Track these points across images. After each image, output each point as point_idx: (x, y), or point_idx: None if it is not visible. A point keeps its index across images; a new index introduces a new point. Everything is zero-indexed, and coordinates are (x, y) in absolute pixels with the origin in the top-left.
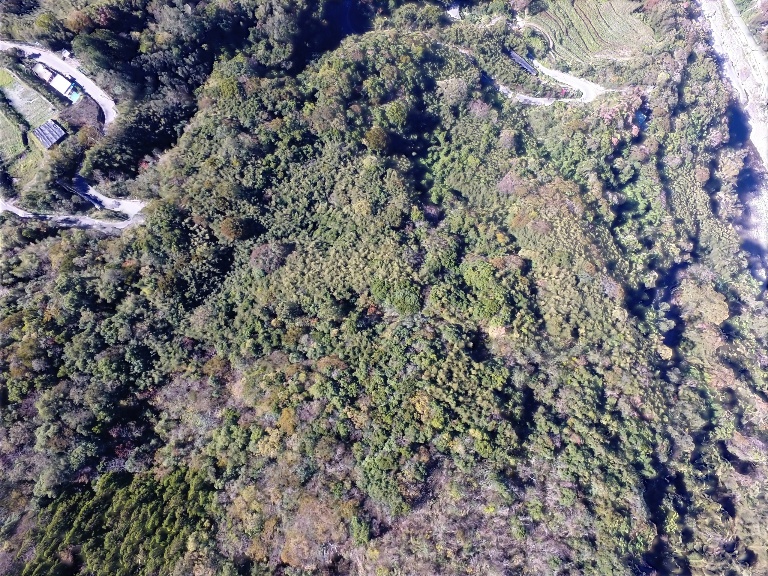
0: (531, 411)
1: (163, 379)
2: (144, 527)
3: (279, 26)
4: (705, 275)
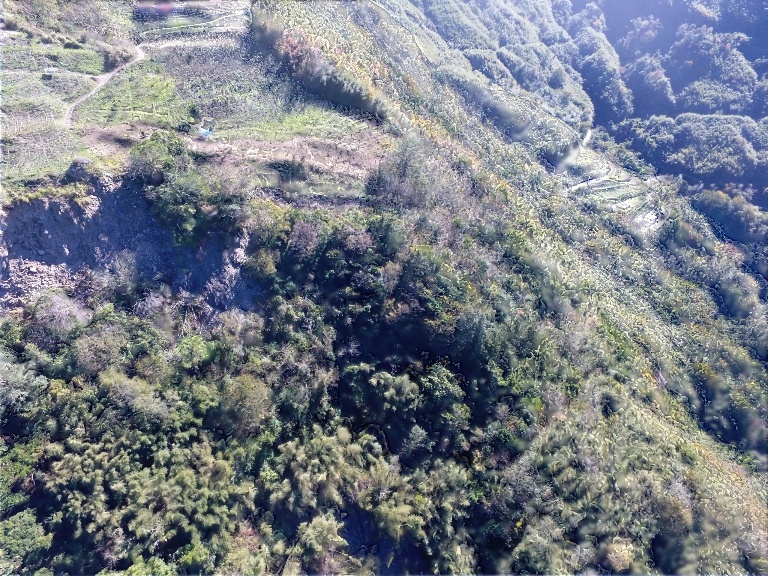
0: None
1: None
2: None
3: (767, 338)
4: None
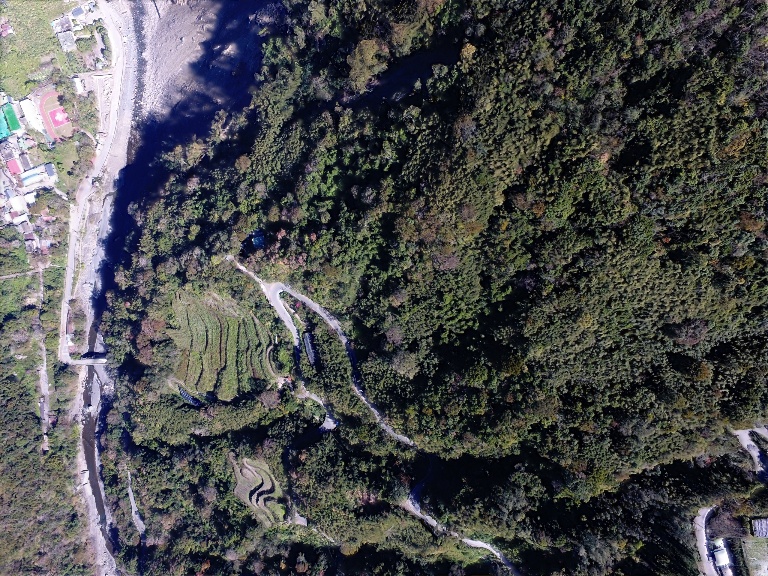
0: None
1: None
2: None
3: None
4: (322, 85)
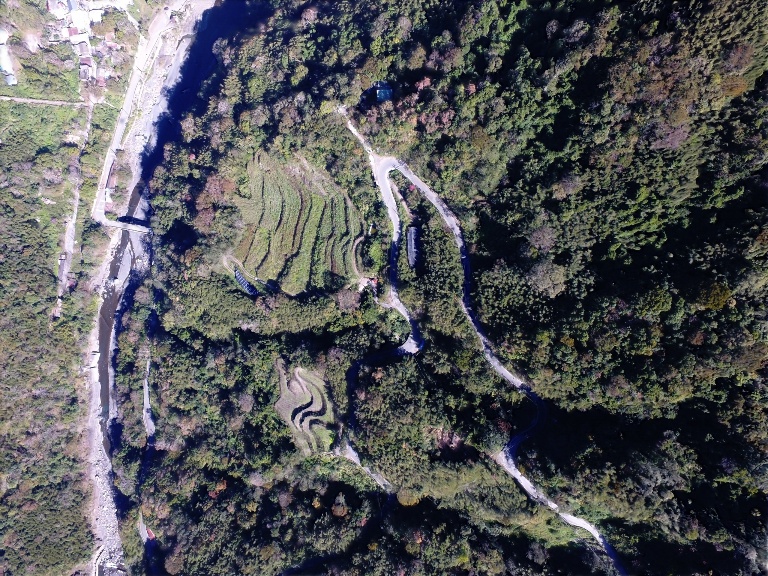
0: None
1: None
2: None
3: None
4: None
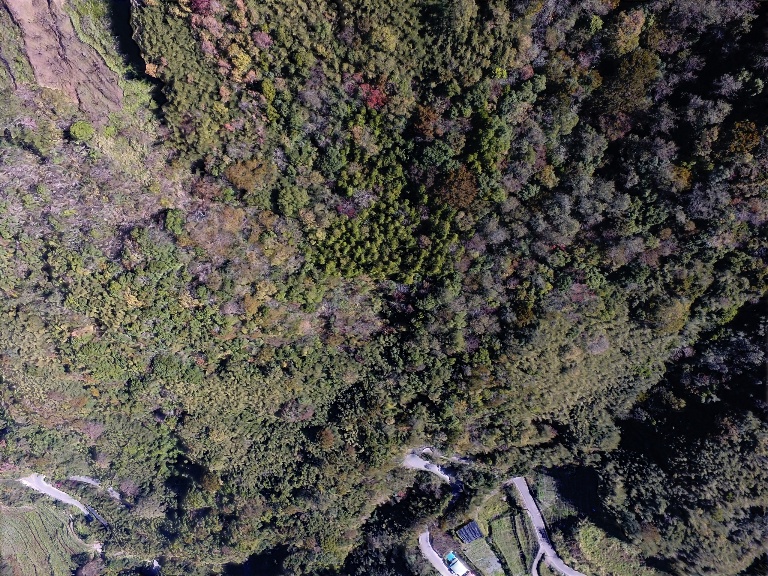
0: None
1: (377, 337)
2: None
3: None
4: None
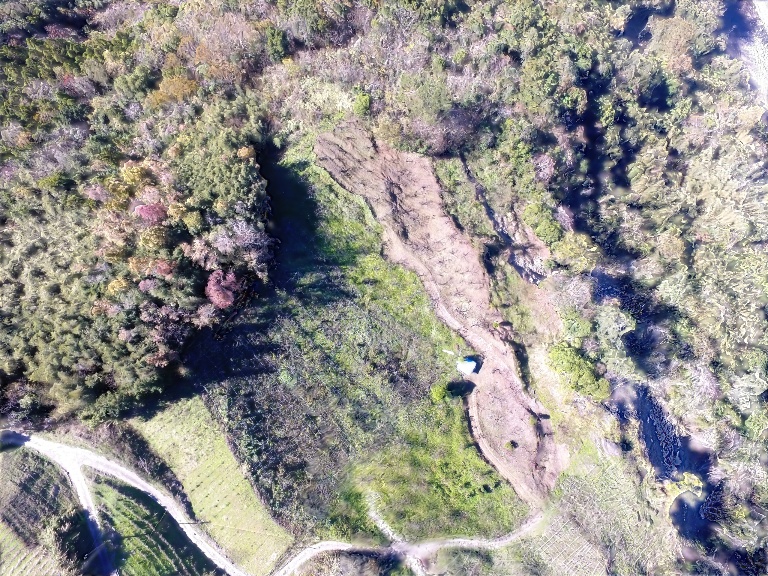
0: (466, 13)
1: (103, 6)
2: (64, 55)
3: None
4: None
